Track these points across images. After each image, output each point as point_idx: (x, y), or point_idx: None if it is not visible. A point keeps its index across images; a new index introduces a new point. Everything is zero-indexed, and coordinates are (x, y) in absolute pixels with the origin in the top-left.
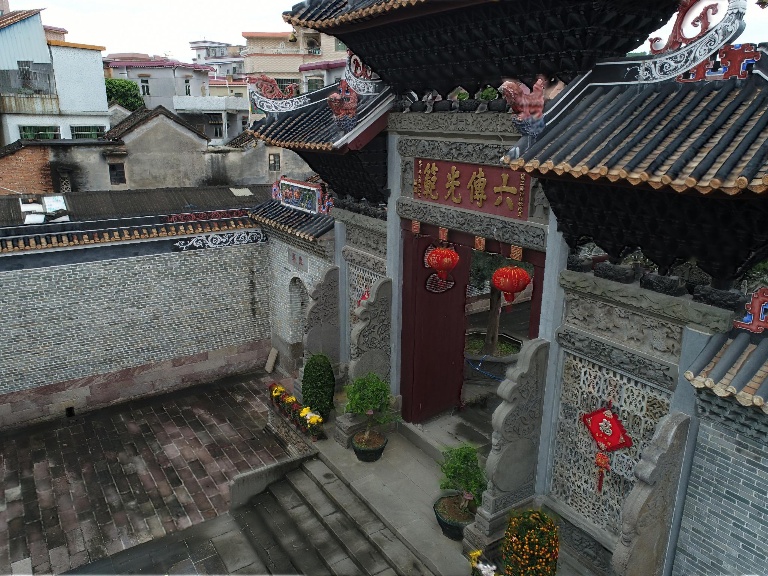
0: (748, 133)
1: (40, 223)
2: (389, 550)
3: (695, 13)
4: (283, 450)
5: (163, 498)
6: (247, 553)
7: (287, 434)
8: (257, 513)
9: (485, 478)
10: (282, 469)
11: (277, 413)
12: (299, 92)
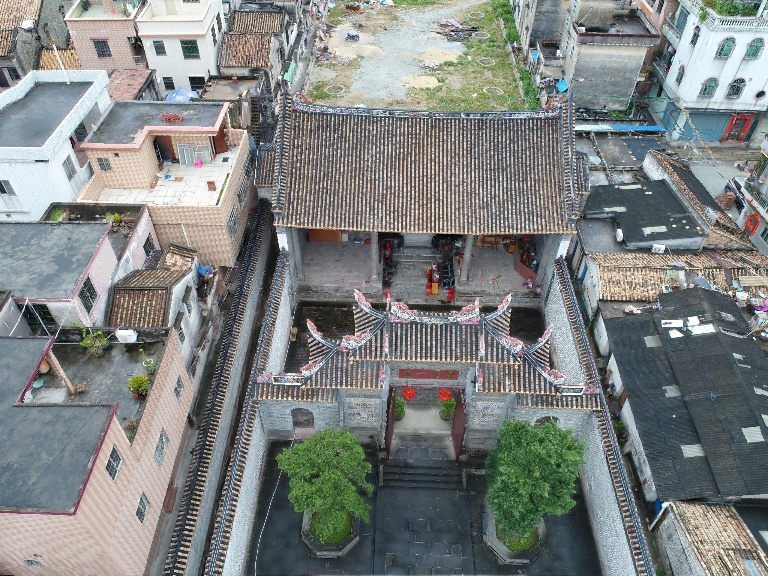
0: None
1: (577, 309)
2: (404, 401)
3: None
4: None
5: None
6: None
7: None
8: None
9: (407, 431)
10: None
11: None
12: (537, 342)
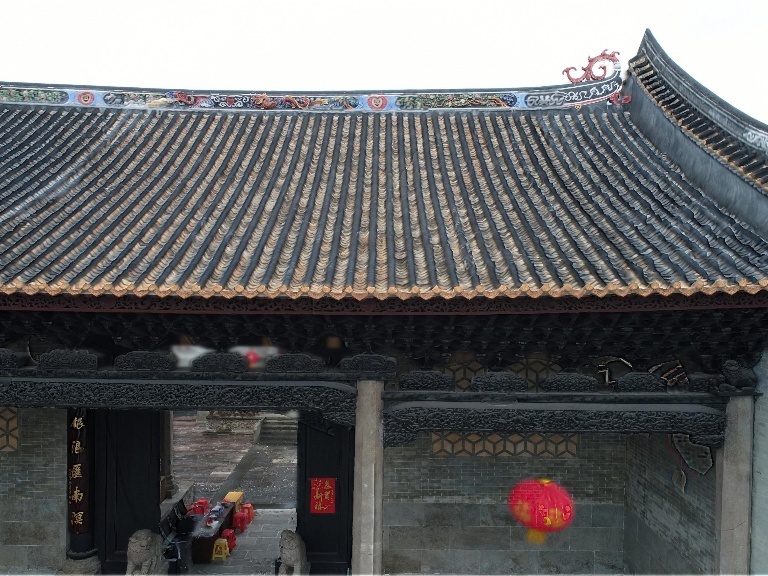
0: None
1: None
2: None
3: None
4: (229, 434)
5: (219, 452)
6: (281, 446)
7: (229, 425)
8: (267, 439)
9: None
10: (261, 424)
11: (220, 418)
12: None
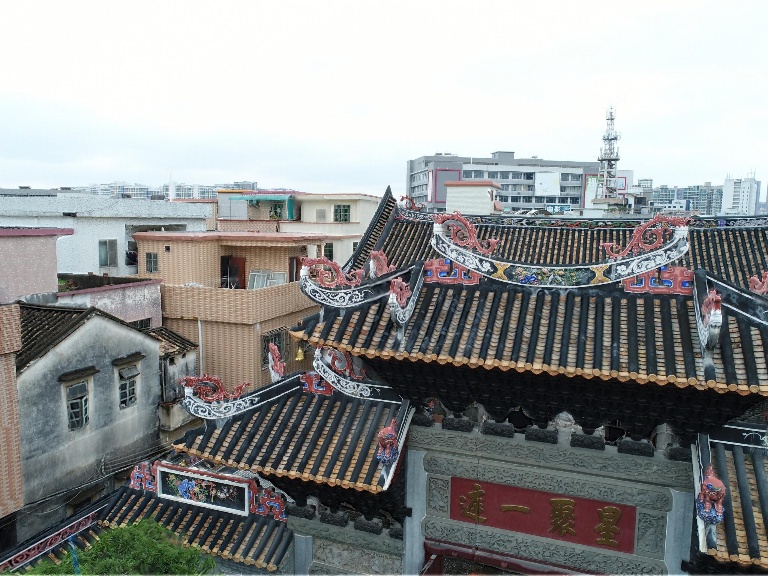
0: None
1: None
2: None
3: (340, 355)
4: None
5: None
6: None
7: None
8: None
9: None
10: None
11: None
12: None
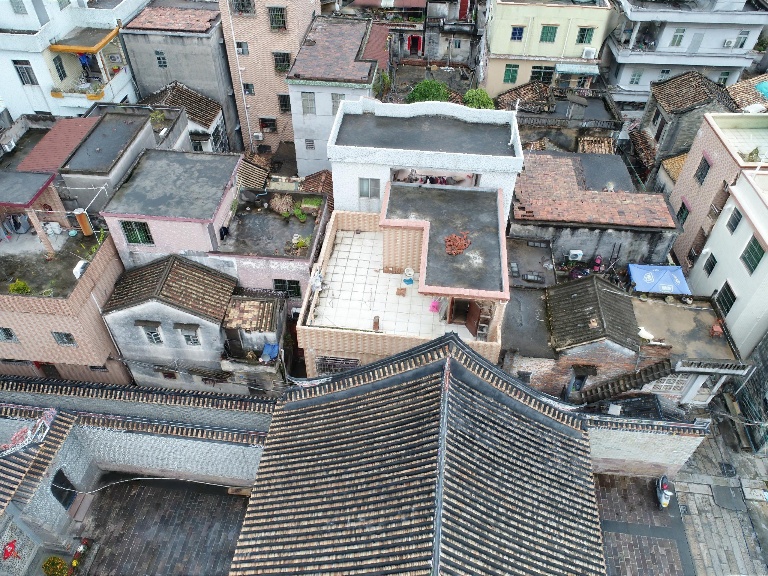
0: (7, 466)
1: None
2: None
3: None
4: None
5: None
6: None
7: None
8: None
9: None
10: None
11: None
12: None
